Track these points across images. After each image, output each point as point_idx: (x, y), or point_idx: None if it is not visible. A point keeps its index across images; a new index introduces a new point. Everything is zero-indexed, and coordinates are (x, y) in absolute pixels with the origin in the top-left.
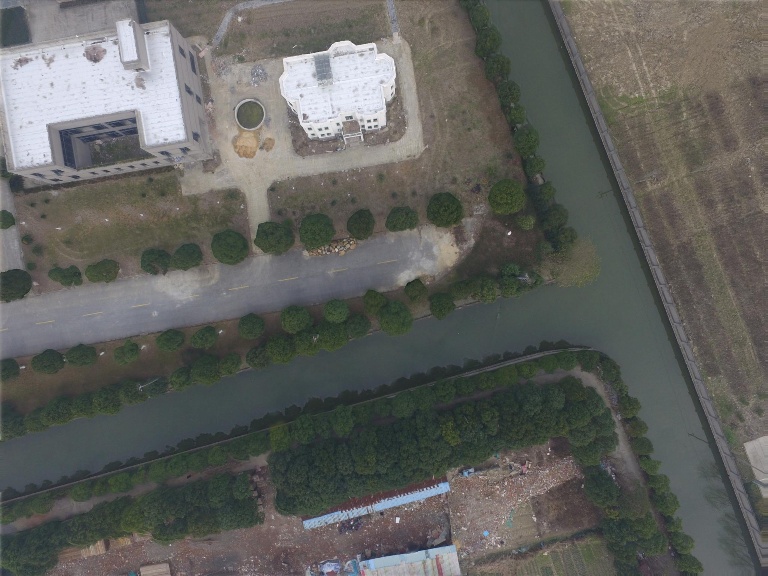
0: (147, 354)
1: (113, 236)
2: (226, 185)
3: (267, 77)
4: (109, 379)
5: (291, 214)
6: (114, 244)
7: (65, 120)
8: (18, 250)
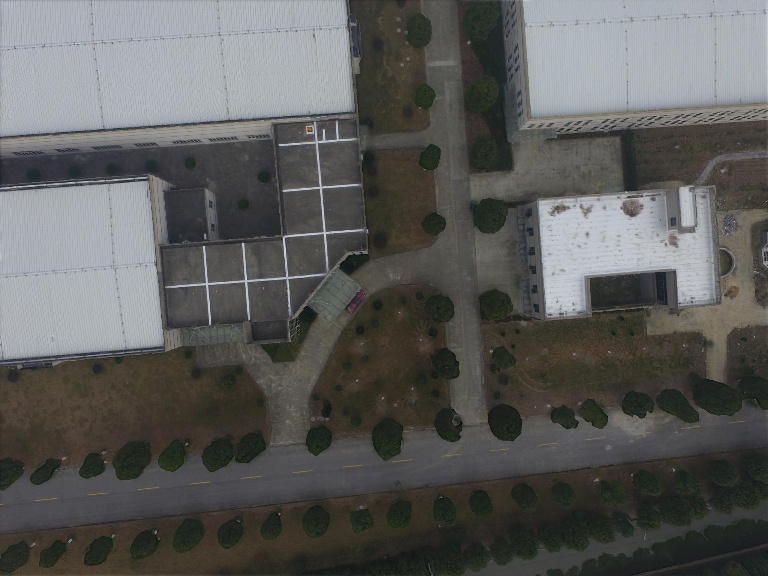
0: (599, 487)
1: (578, 370)
2: (689, 328)
3: (738, 227)
4: (559, 509)
5: (749, 361)
6: (578, 378)
7: (598, 271)
8: (479, 376)
